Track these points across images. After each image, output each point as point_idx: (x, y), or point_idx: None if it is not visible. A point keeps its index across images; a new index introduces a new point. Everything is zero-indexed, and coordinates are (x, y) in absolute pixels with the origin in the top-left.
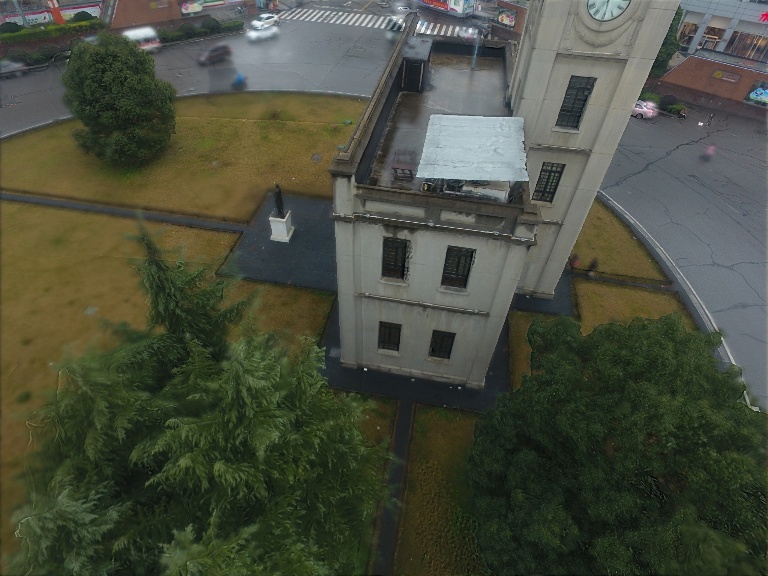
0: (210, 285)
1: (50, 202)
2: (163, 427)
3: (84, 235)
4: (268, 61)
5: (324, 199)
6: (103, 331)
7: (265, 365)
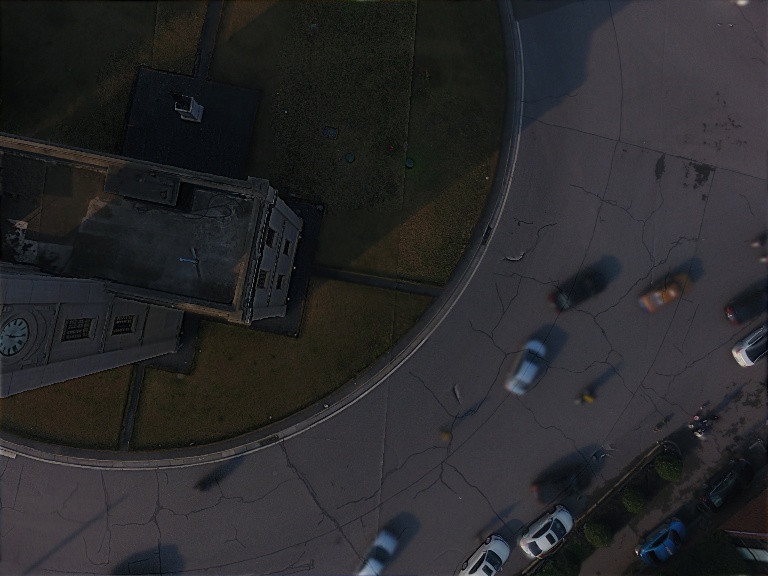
0: None
1: None
2: None
3: None
4: (626, 37)
5: (249, 146)
6: (78, 1)
7: None
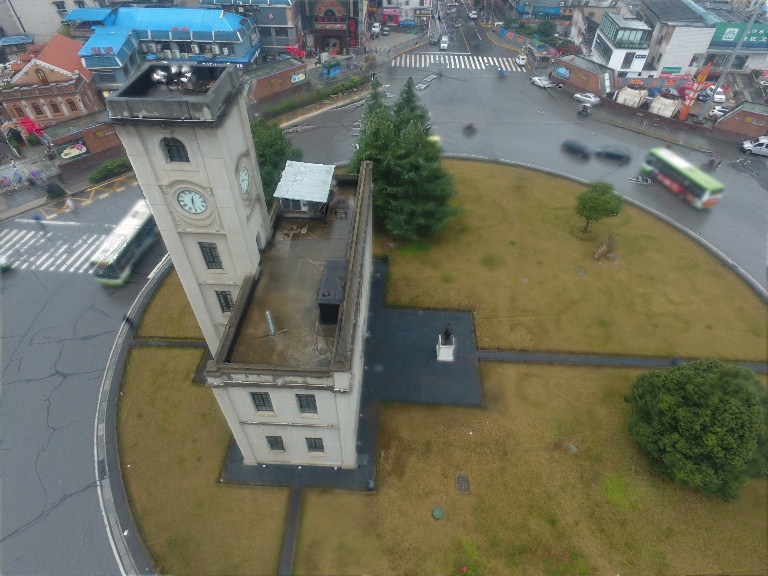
0: (413, 174)
1: (663, 364)
2: (398, 138)
3: (592, 331)
4: None
5: (426, 403)
6: (507, 271)
7: (373, 128)
